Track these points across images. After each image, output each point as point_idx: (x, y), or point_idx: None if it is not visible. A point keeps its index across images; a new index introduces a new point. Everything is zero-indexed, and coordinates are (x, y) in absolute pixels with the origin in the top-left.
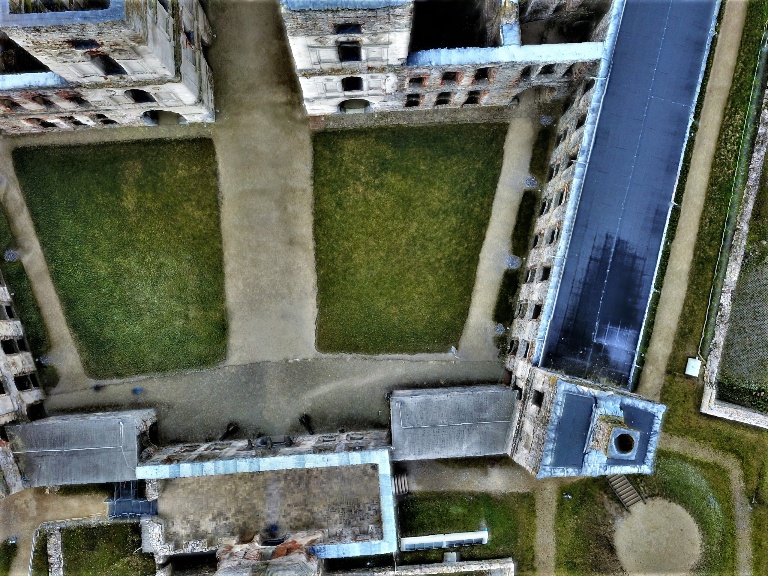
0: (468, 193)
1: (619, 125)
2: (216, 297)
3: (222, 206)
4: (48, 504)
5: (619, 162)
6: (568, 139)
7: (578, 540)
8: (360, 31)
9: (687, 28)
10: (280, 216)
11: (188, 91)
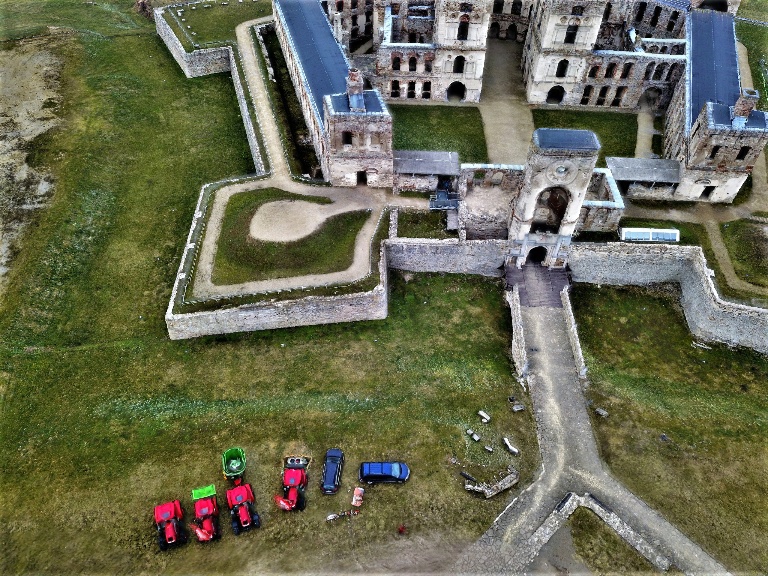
0: (621, 132)
1: (703, 72)
2: (482, 155)
3: (484, 126)
4: (393, 198)
5: (708, 81)
6: (675, 98)
7: (742, 245)
8: (581, 15)
9: (724, 51)
10: (517, 132)
11: (483, 63)
